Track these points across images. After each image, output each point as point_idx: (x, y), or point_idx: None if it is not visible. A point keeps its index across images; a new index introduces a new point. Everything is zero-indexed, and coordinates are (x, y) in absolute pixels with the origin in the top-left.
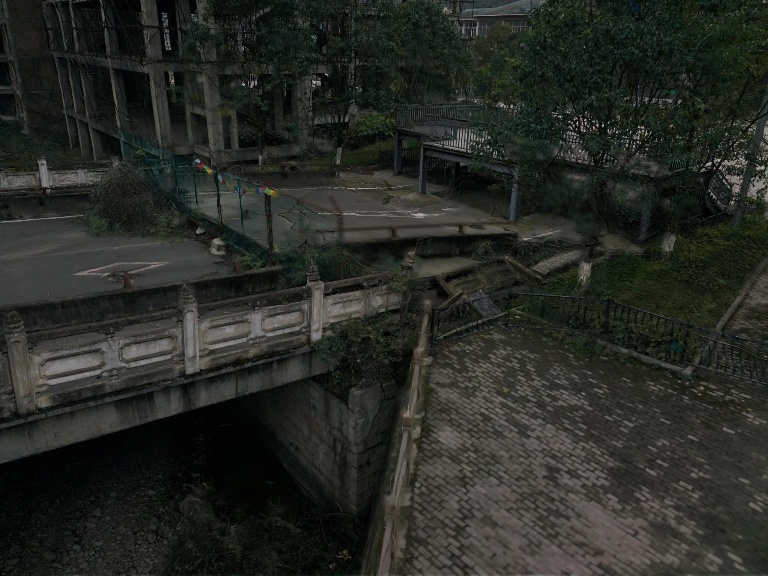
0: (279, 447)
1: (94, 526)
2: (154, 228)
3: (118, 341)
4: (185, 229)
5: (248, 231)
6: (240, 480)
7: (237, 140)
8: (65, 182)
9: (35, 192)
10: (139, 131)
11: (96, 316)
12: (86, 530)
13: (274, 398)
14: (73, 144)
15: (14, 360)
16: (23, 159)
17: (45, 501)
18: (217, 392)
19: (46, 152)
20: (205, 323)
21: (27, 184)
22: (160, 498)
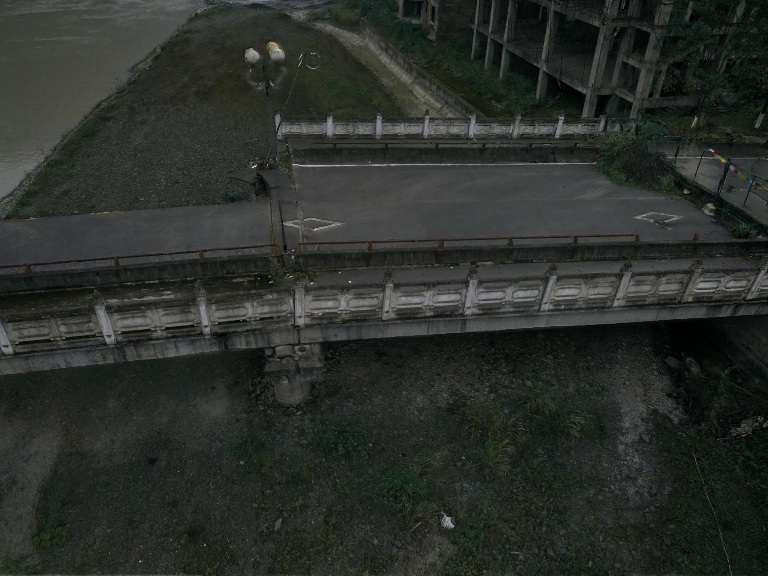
0: (728, 344)
1: (620, 358)
2: (658, 186)
3: (728, 278)
4: (676, 189)
5: (740, 205)
6: (700, 357)
7: (660, 90)
8: (568, 131)
9: (550, 137)
10: (567, 68)
11: (677, 253)
12: (617, 359)
13: (764, 319)
14: (476, 56)
15: (692, 279)
16: (443, 68)
17: (592, 337)
18: (748, 310)
19: (457, 62)
20: (766, 276)
21: (548, 131)
22: (651, 353)
